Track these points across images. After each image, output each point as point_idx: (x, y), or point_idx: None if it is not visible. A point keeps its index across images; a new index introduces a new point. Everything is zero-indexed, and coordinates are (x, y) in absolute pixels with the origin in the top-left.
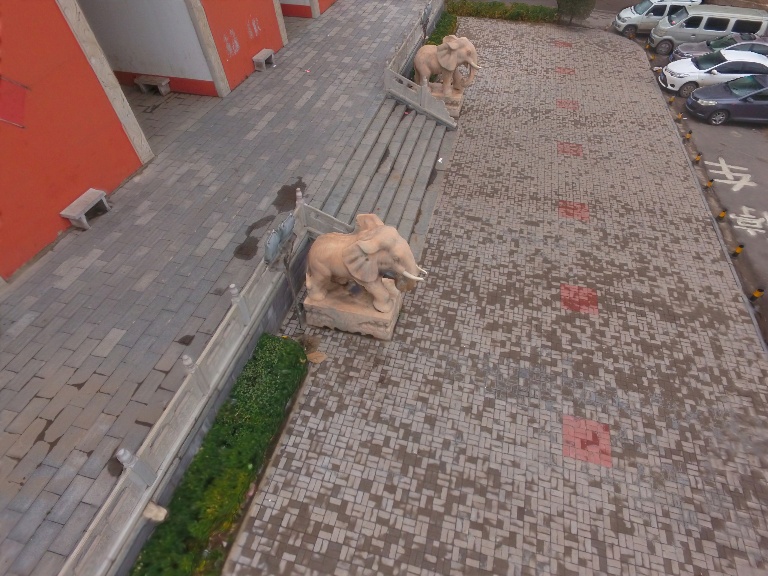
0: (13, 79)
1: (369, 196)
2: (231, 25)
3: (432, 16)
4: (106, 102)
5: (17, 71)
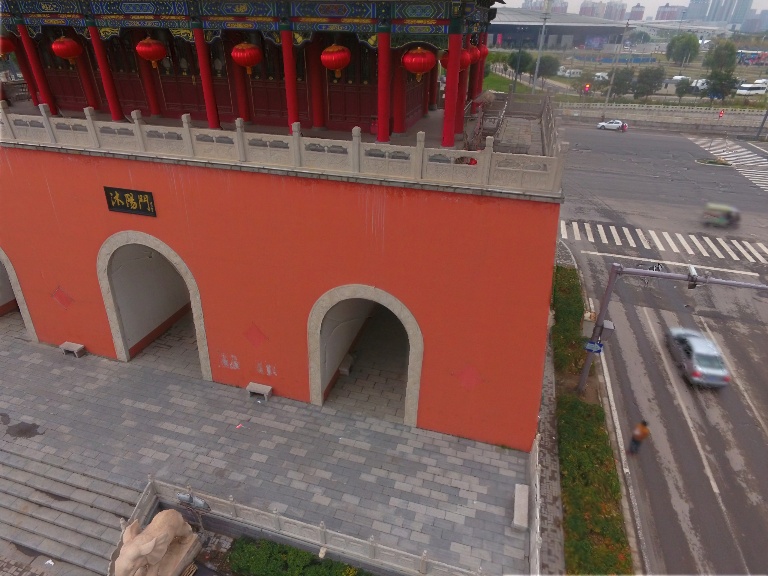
0: (70, 295)
1: (6, 484)
2: (237, 353)
3: (409, 570)
4: (109, 326)
5: (75, 294)
